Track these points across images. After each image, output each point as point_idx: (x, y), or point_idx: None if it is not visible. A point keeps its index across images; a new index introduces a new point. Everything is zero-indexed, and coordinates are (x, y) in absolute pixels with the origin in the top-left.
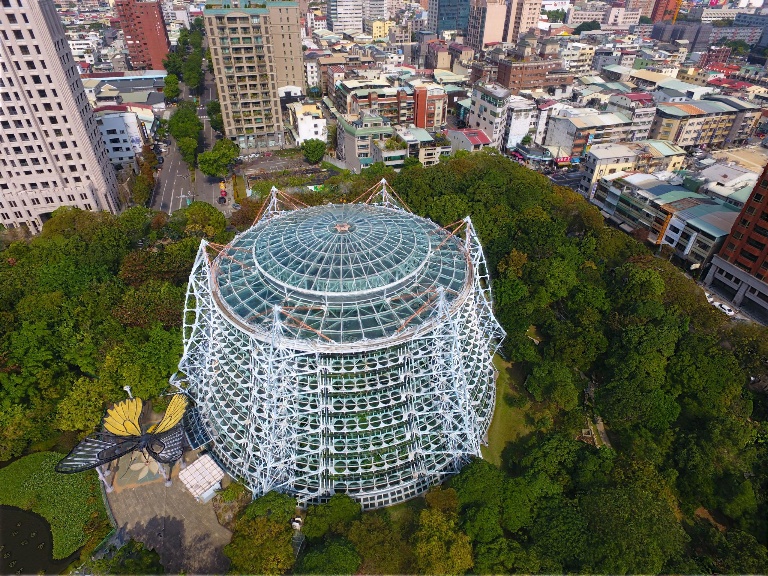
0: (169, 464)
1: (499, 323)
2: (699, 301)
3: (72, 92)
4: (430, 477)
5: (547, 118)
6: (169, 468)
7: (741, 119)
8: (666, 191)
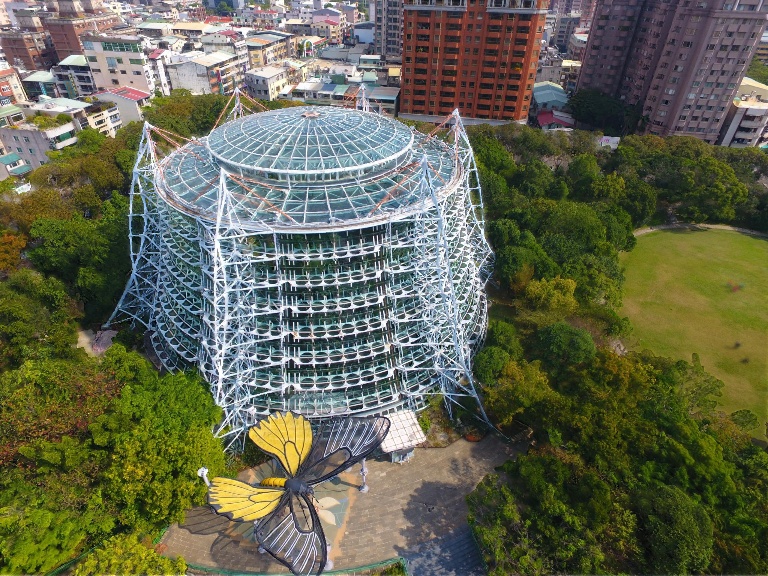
0: (334, 484)
1: None
2: None
3: None
4: None
5: (164, 67)
6: (340, 485)
7: (289, 45)
8: (333, 87)
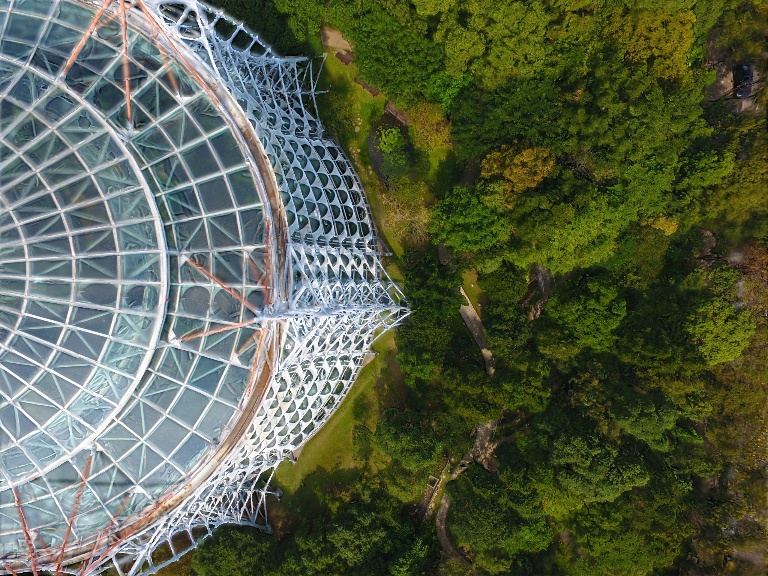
0: None
1: (409, 294)
2: (767, 399)
3: None
4: None
5: None
6: None
7: None
8: None
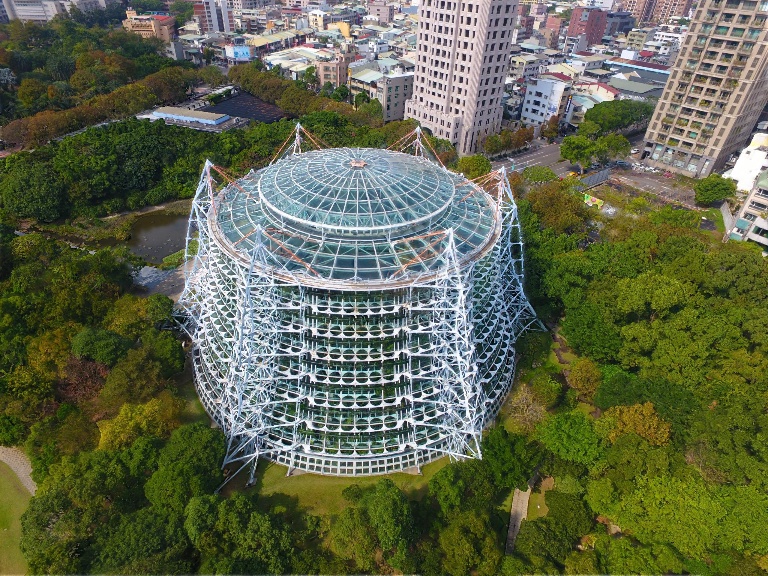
0: None
1: (488, 438)
2: None
3: (488, 38)
4: (227, 419)
5: None
6: None
7: None
8: None
